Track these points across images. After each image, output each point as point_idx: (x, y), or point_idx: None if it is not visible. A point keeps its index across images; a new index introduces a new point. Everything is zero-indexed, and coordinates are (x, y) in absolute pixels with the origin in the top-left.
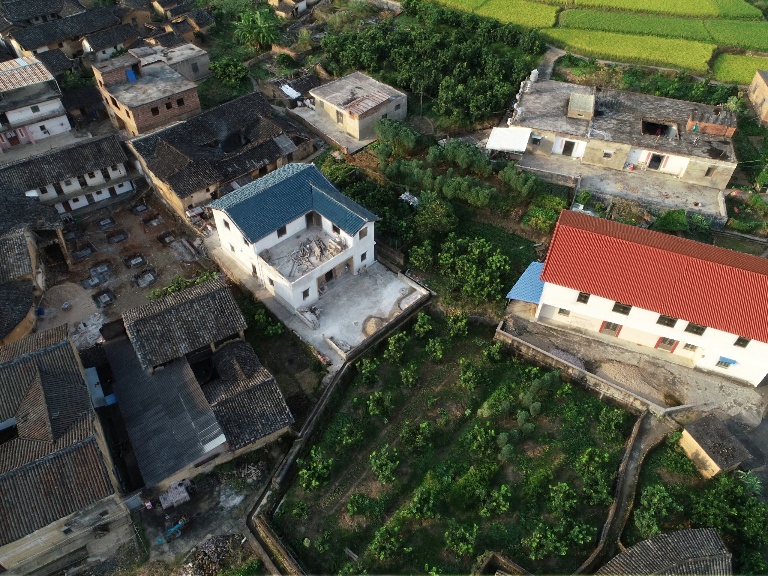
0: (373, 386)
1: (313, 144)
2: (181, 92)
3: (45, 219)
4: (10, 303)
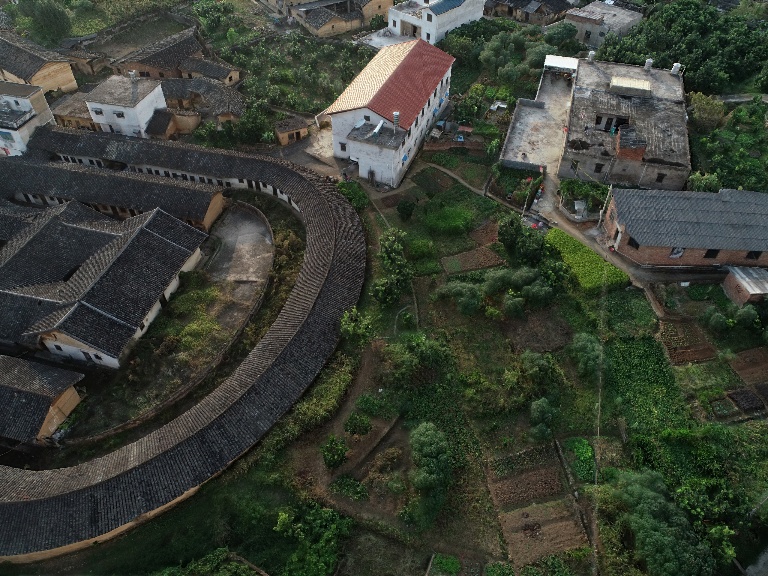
0: None
1: None
2: None
3: None
4: None
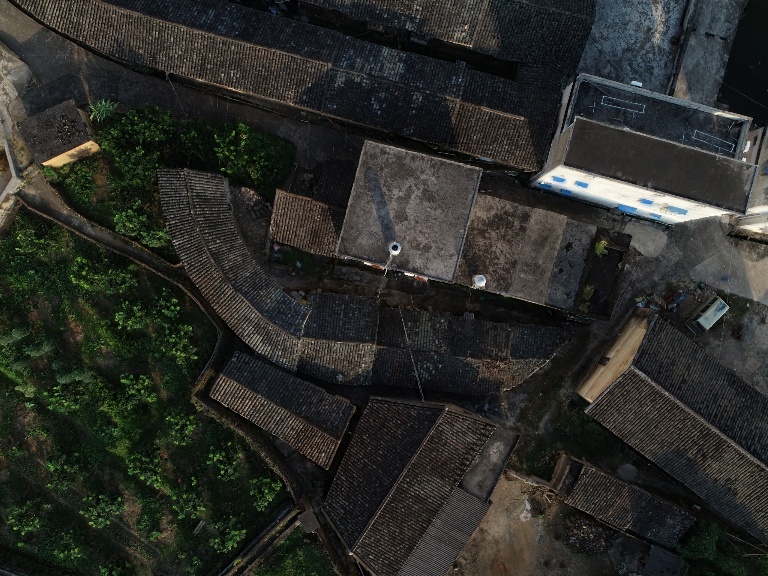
0: None
1: None
2: None
3: None
4: None
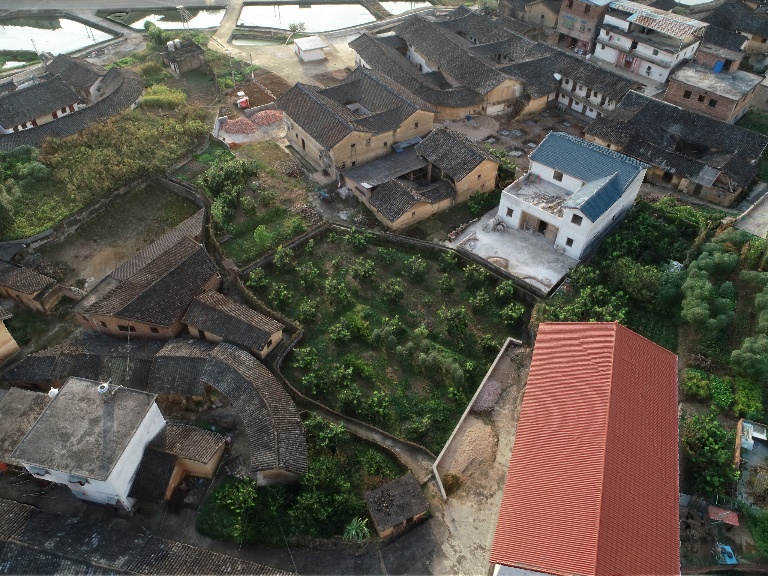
0: (441, 272)
1: (739, 204)
2: (719, 95)
3: (537, 89)
4: (460, 98)
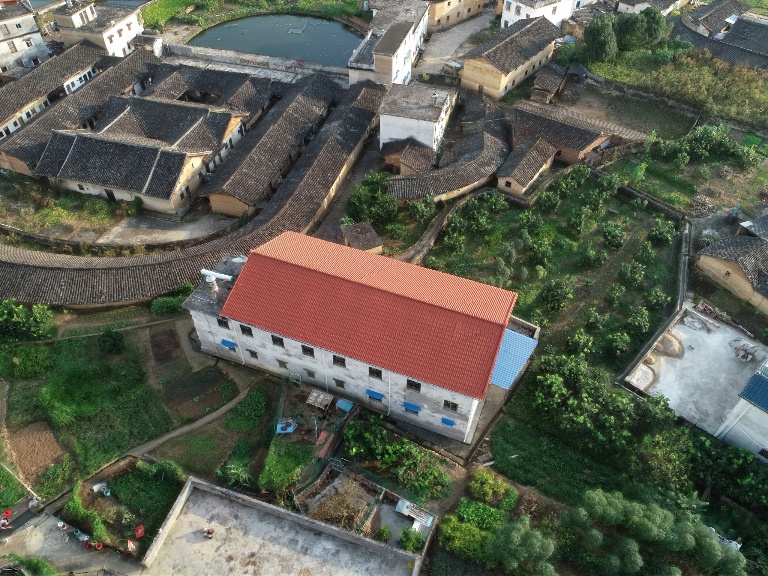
0: None
1: None
2: None
3: None
4: None
